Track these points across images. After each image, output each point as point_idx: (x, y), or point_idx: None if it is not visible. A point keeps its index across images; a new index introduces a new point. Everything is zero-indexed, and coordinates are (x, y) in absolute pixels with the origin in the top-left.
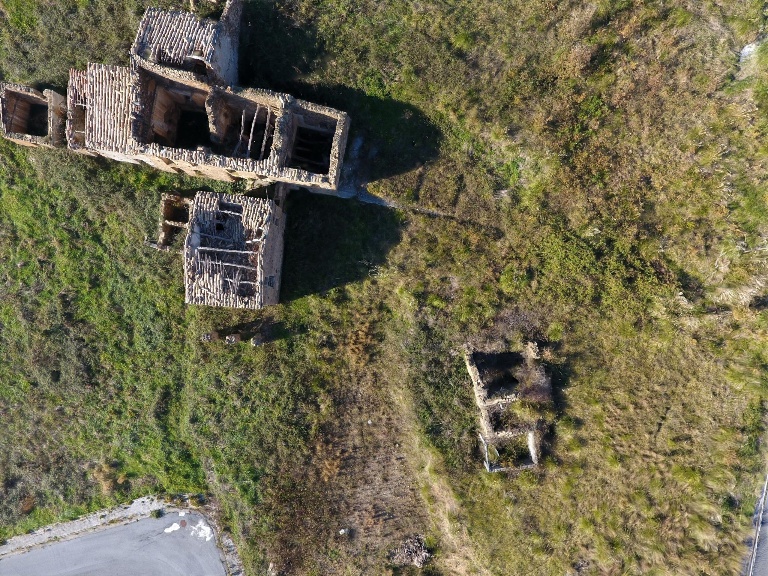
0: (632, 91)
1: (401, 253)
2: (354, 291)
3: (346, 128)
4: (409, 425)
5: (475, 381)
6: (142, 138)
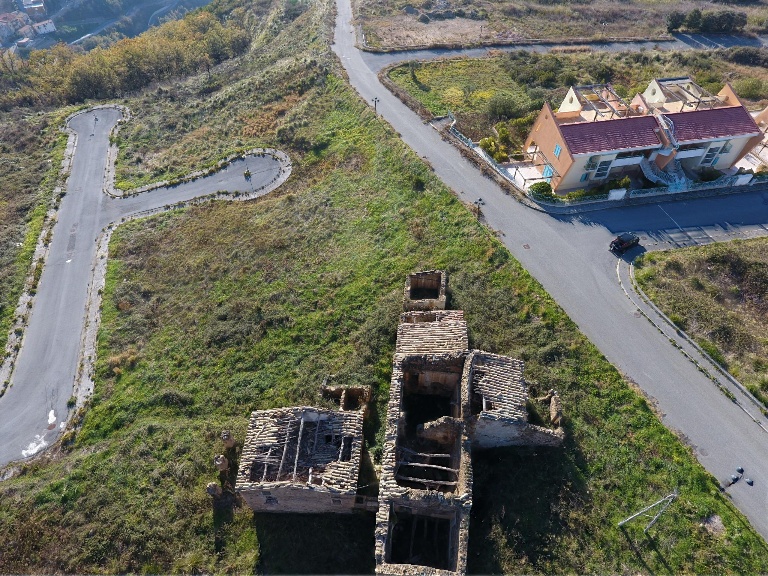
0: None
1: None
2: None
3: None
4: None
5: None
6: (408, 365)
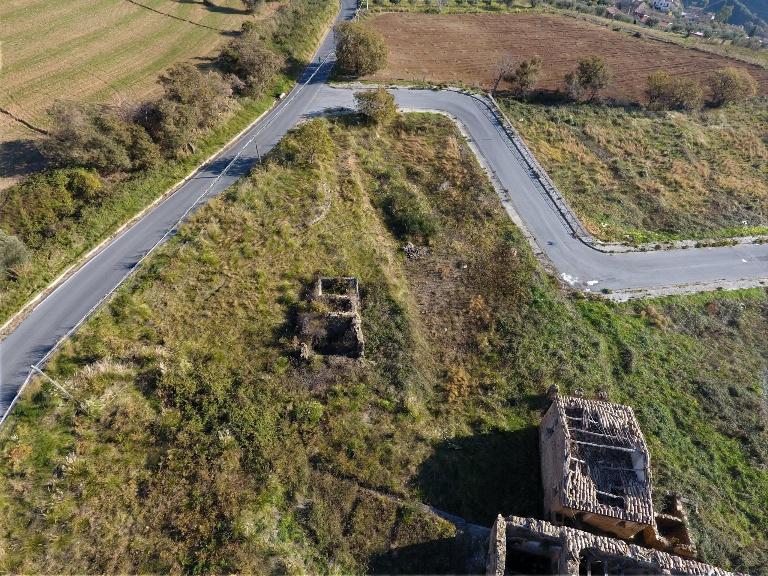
0: None
1: (418, 453)
2: (464, 429)
3: None
4: (414, 321)
5: None
6: None
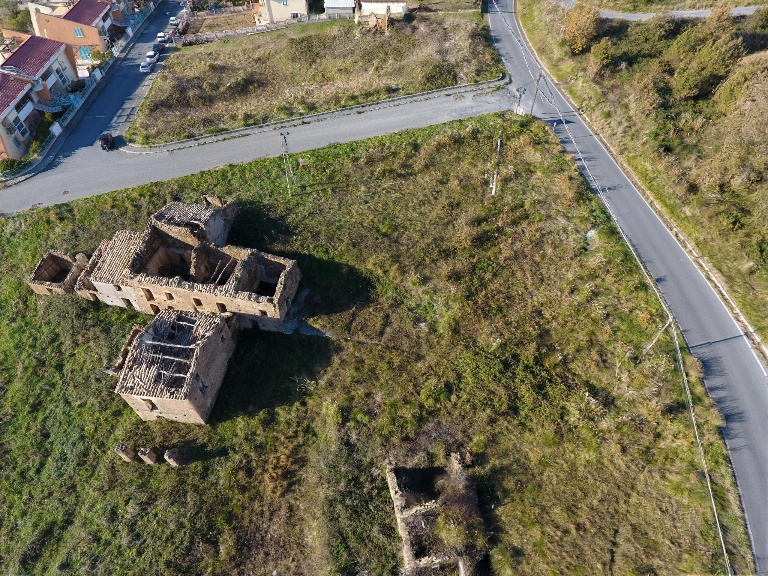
0: (513, 256)
1: (330, 372)
2: (283, 412)
3: (296, 275)
4: (320, 571)
5: (392, 489)
6: (135, 272)
